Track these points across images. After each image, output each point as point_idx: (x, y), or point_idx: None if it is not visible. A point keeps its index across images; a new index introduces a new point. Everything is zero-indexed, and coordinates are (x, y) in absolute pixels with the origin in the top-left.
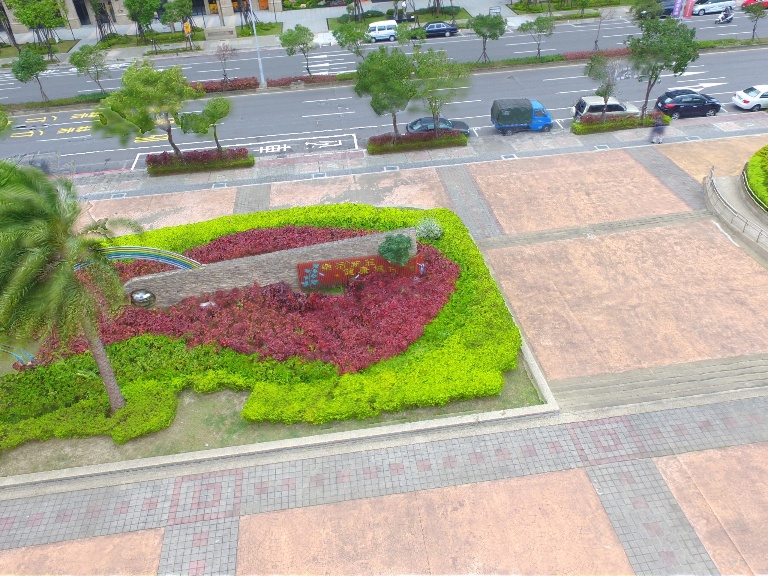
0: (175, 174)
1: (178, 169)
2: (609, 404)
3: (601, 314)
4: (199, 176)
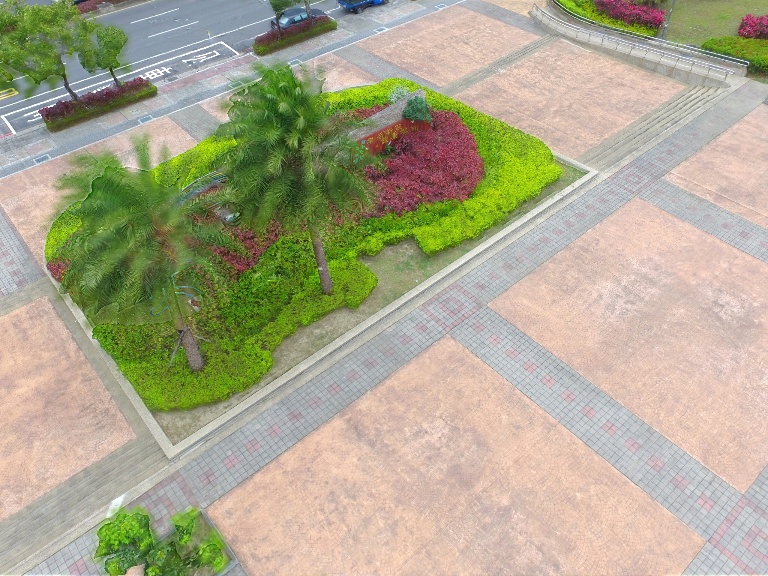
0: (80, 123)
1: (83, 116)
2: (616, 161)
3: (556, 117)
4: (110, 117)
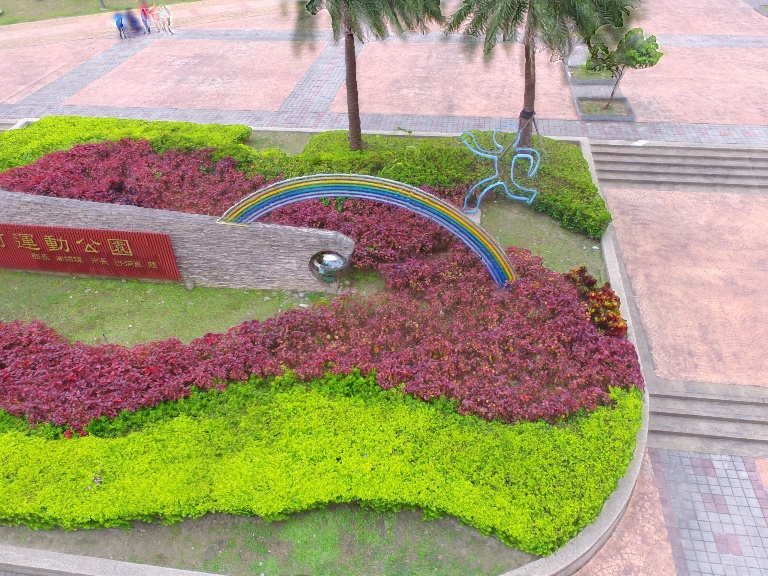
0: None
1: None
2: None
3: None
4: None
